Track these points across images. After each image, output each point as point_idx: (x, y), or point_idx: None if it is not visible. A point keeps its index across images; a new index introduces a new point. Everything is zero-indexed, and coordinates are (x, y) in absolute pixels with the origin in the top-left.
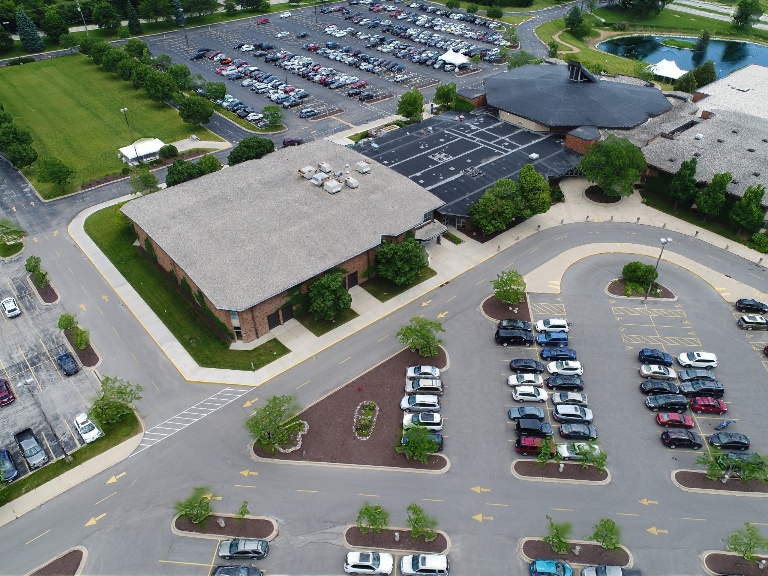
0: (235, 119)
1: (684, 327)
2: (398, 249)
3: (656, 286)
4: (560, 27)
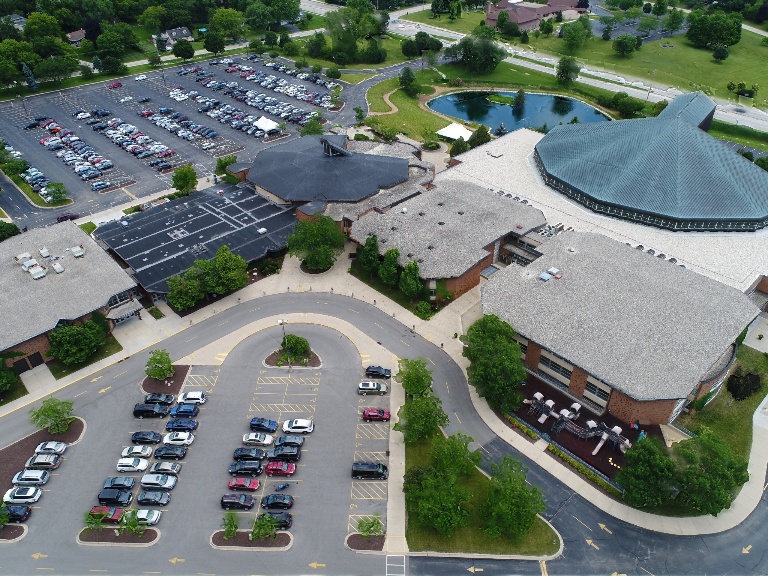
0: (29, 194)
1: (310, 394)
2: (66, 333)
3: (308, 355)
4: (397, 85)
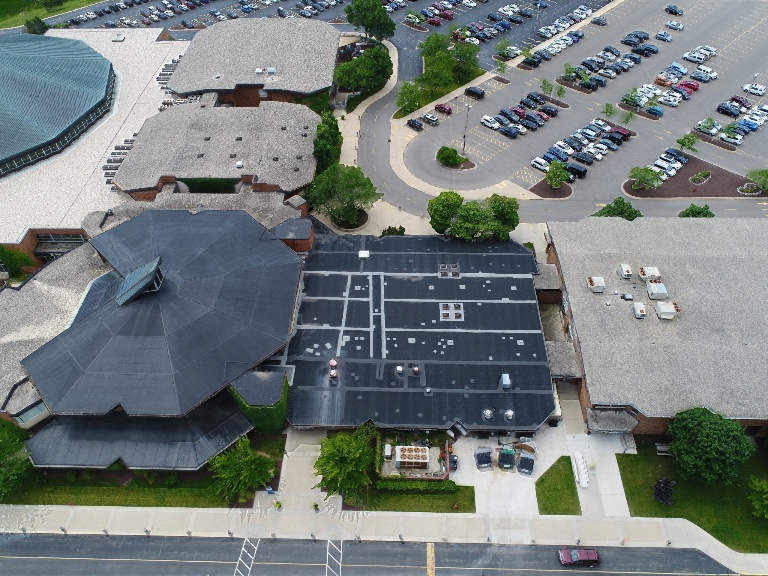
0: None
1: None
2: None
3: None
4: None
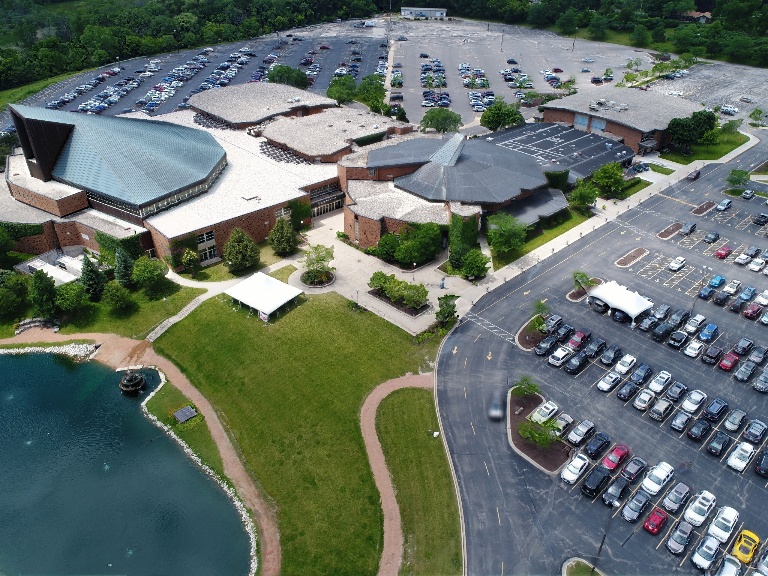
0: None
1: None
2: None
3: None
4: None
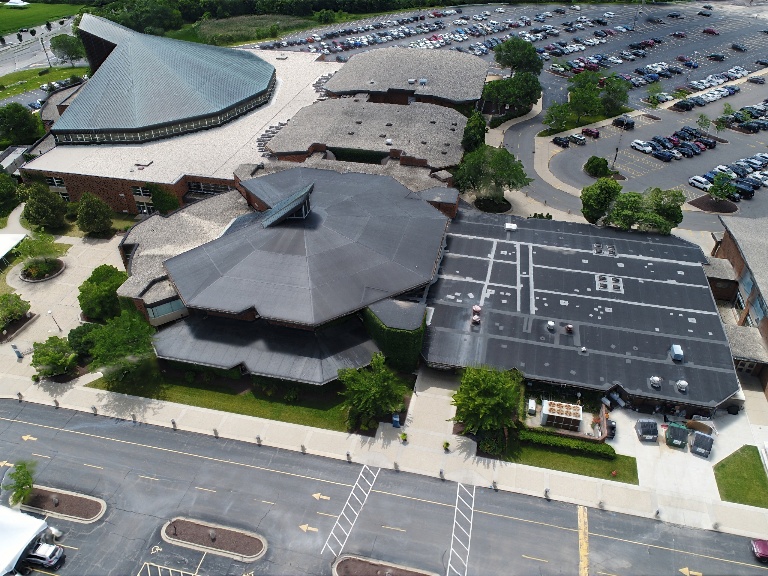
0: None
1: None
2: None
3: None
4: None
